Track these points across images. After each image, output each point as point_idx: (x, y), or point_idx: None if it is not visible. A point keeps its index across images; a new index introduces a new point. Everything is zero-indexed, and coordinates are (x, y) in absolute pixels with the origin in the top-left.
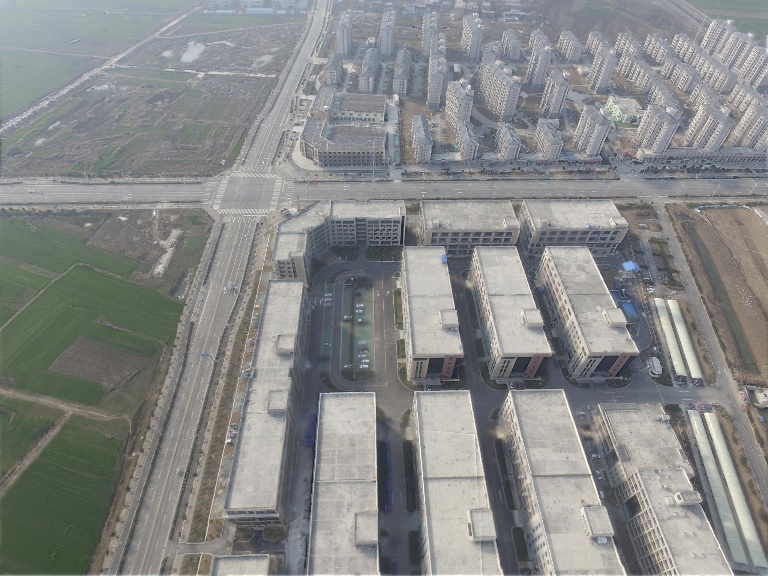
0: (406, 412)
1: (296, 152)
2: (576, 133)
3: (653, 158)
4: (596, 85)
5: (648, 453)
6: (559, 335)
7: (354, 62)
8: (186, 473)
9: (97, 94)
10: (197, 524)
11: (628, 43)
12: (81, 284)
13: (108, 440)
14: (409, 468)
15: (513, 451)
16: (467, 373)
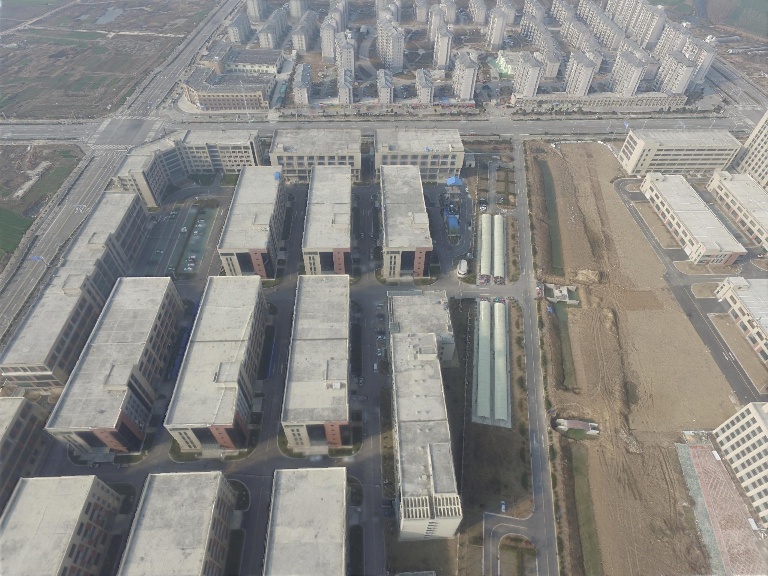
0: None
1: (183, 98)
2: (453, 80)
3: (524, 102)
4: (491, 42)
5: (418, 328)
6: (381, 244)
7: (265, 24)
8: None
9: (4, 51)
10: None
11: (532, 6)
12: None
13: None
14: None
15: None
16: (285, 274)
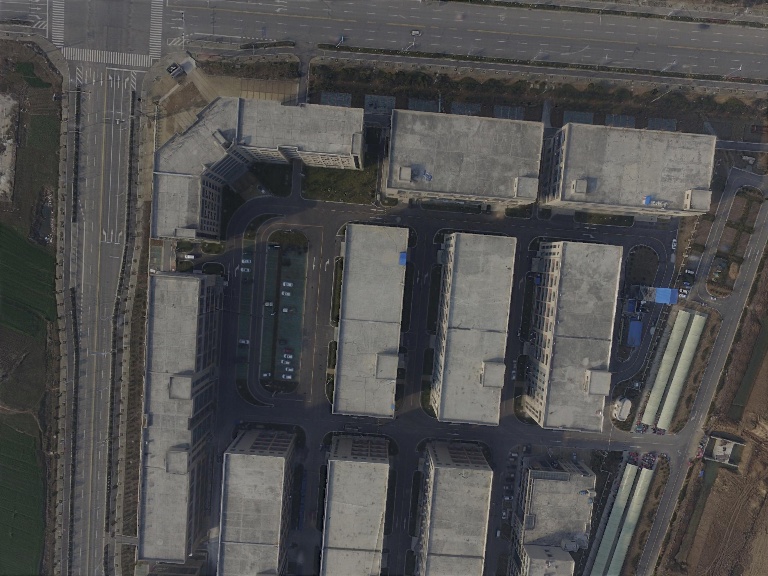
0: (328, 436)
1: None
2: None
3: None
4: None
5: (555, 525)
6: None
7: None
8: (108, 477)
9: None
10: (128, 522)
11: None
12: None
13: (20, 435)
14: (322, 496)
15: (425, 502)
16: (405, 394)
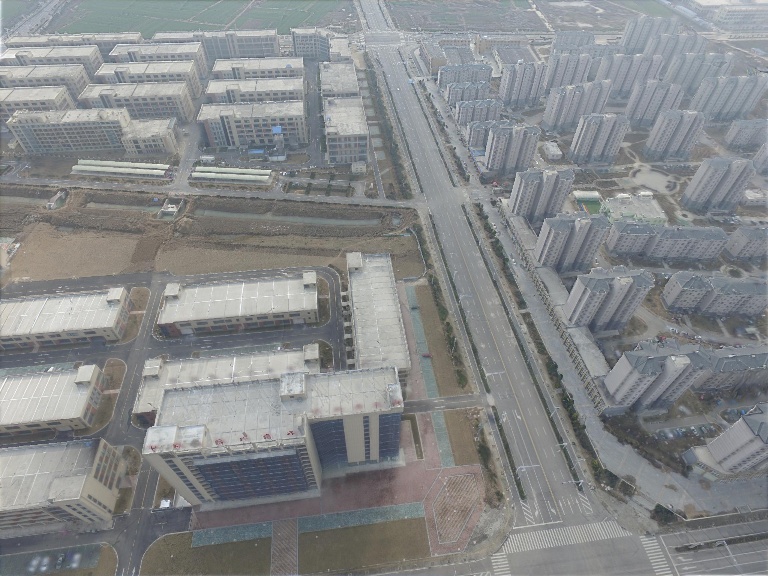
0: (203, 84)
1: None
2: None
3: None
4: None
5: (140, 127)
6: None
7: None
8: None
9: None
10: None
11: None
12: (299, 15)
13: None
14: None
15: None
16: None
